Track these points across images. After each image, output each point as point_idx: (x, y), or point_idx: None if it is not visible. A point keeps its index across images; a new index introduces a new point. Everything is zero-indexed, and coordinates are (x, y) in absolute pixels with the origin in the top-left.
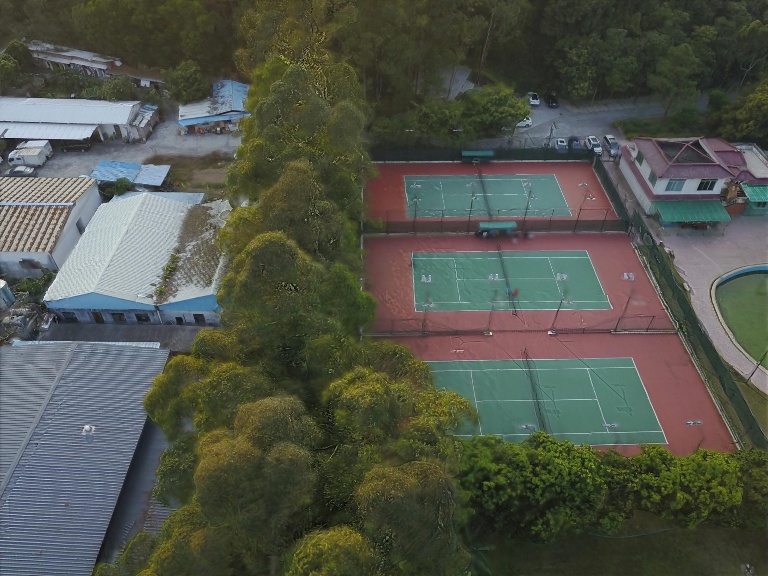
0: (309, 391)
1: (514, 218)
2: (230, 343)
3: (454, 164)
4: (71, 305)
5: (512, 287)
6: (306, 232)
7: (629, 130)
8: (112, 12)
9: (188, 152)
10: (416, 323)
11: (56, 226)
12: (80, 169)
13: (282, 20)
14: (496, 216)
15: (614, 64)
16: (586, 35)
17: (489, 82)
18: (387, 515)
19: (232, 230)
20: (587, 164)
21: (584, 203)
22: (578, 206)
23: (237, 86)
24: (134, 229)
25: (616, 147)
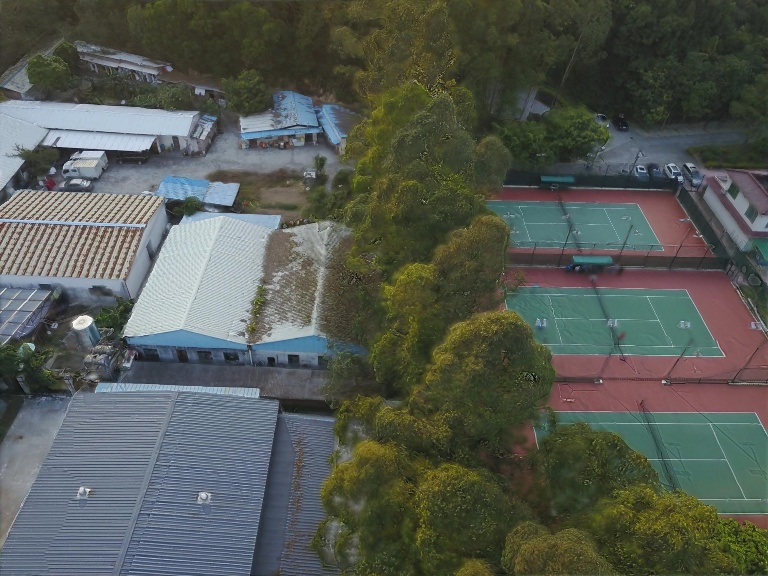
0: (560, 506)
1: (605, 251)
2: (446, 437)
3: (531, 189)
4: (155, 342)
5: (615, 329)
6: (494, 294)
7: (708, 158)
8: (171, 16)
9: (252, 168)
10: None
11: (129, 250)
12: (139, 183)
13: (418, 42)
14: (585, 248)
15: (693, 89)
16: (662, 57)
17: (556, 102)
18: None
19: (409, 289)
20: (669, 194)
21: (686, 239)
22: (679, 242)
23: (299, 98)
24: (216, 257)
25: (699, 177)
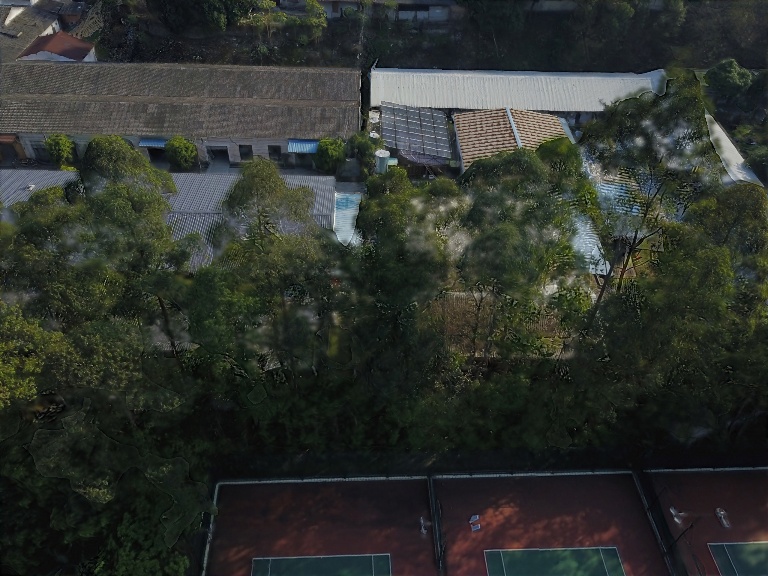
0: None
1: None
2: None
3: None
4: None
5: None
6: None
7: None
8: None
9: None
10: (460, 550)
11: None
12: None
13: (641, 119)
14: None
15: None
16: None
17: None
18: None
19: None
20: None
21: None
22: None
23: None
24: None
25: None
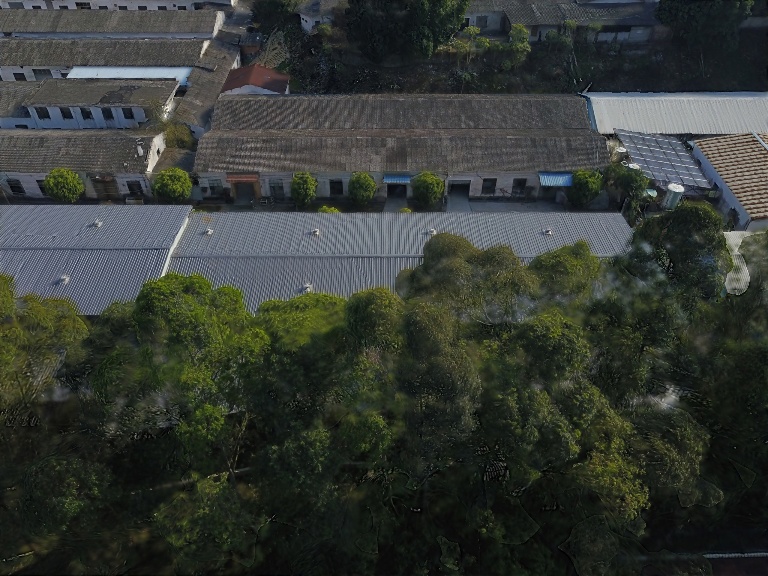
0: None
1: None
2: (604, 263)
3: None
4: None
5: None
6: None
7: None
8: None
9: None
10: None
11: None
12: None
13: None
14: None
15: None
16: None
17: None
18: (408, 332)
19: (762, 237)
20: None
21: None
22: None
23: None
24: None
25: None
